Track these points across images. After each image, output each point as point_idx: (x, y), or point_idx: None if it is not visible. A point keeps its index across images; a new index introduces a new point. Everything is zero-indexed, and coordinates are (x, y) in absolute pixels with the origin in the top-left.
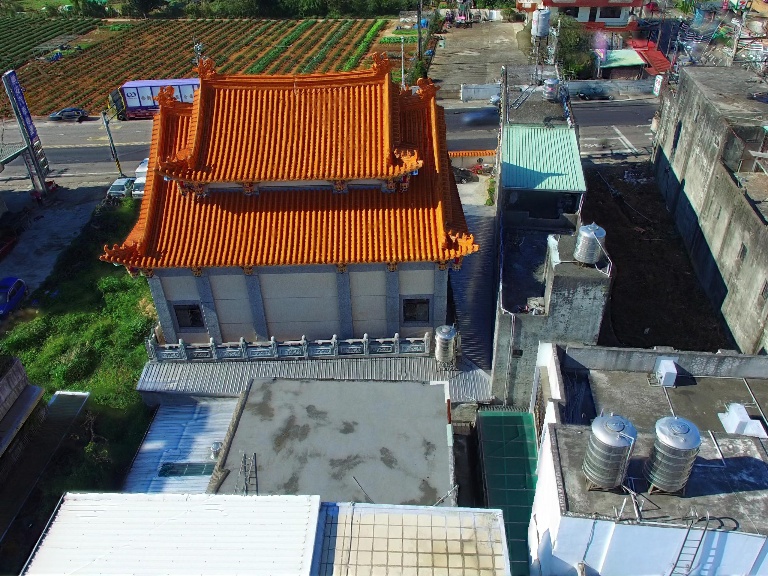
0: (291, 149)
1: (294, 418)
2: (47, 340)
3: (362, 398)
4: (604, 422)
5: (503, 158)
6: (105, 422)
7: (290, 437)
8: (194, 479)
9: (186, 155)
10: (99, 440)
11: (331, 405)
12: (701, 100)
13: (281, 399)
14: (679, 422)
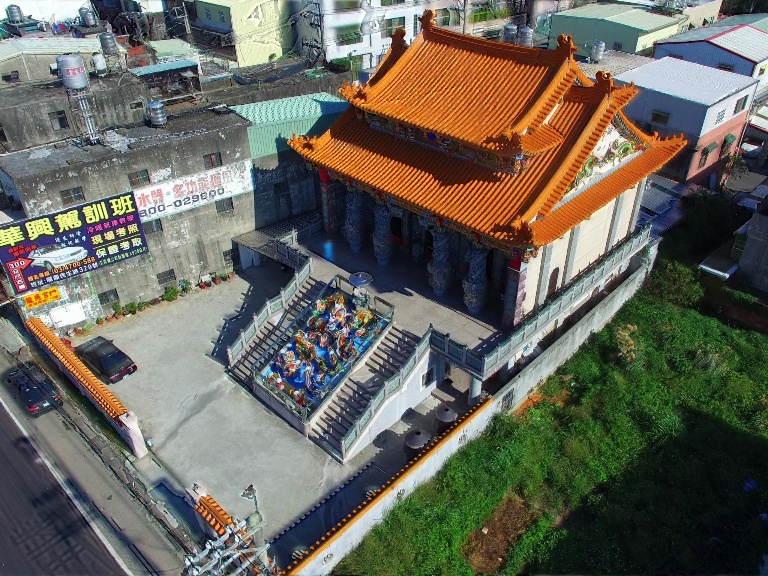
0: None
1: None
2: None
3: None
4: (528, 29)
5: (317, 115)
6: None
7: None
8: None
9: None
10: None
11: None
12: (61, 105)
13: None
14: (509, 24)
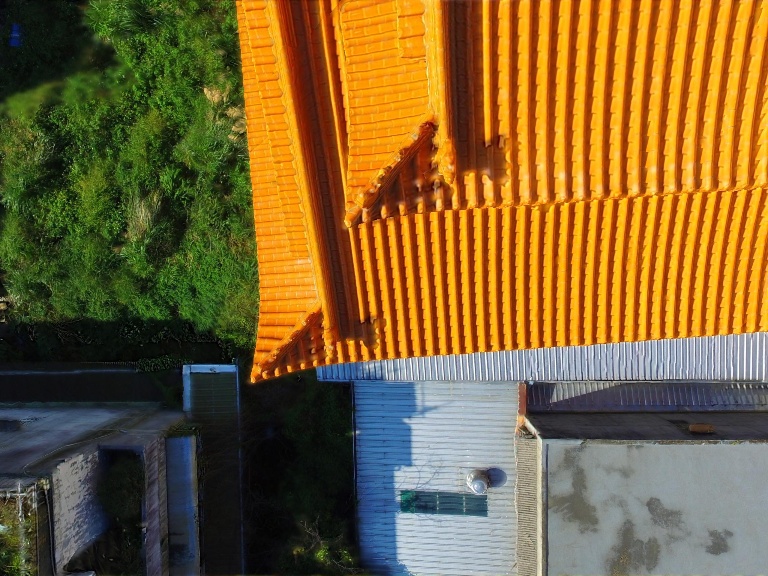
0: (764, 51)
1: (631, 526)
2: (73, 174)
3: (734, 481)
4: None
5: None
6: (286, 420)
7: (632, 564)
8: (455, 521)
9: (422, 126)
10: (332, 544)
11: (686, 497)
12: None
13: (603, 487)
14: None
